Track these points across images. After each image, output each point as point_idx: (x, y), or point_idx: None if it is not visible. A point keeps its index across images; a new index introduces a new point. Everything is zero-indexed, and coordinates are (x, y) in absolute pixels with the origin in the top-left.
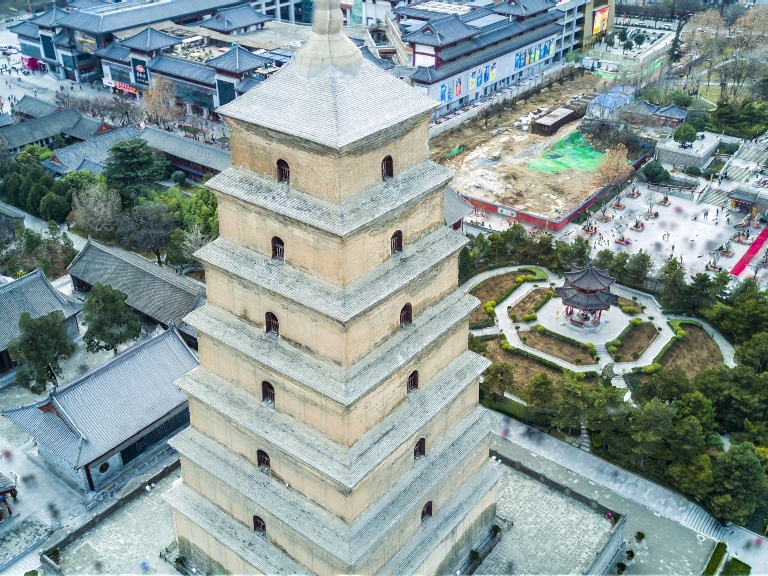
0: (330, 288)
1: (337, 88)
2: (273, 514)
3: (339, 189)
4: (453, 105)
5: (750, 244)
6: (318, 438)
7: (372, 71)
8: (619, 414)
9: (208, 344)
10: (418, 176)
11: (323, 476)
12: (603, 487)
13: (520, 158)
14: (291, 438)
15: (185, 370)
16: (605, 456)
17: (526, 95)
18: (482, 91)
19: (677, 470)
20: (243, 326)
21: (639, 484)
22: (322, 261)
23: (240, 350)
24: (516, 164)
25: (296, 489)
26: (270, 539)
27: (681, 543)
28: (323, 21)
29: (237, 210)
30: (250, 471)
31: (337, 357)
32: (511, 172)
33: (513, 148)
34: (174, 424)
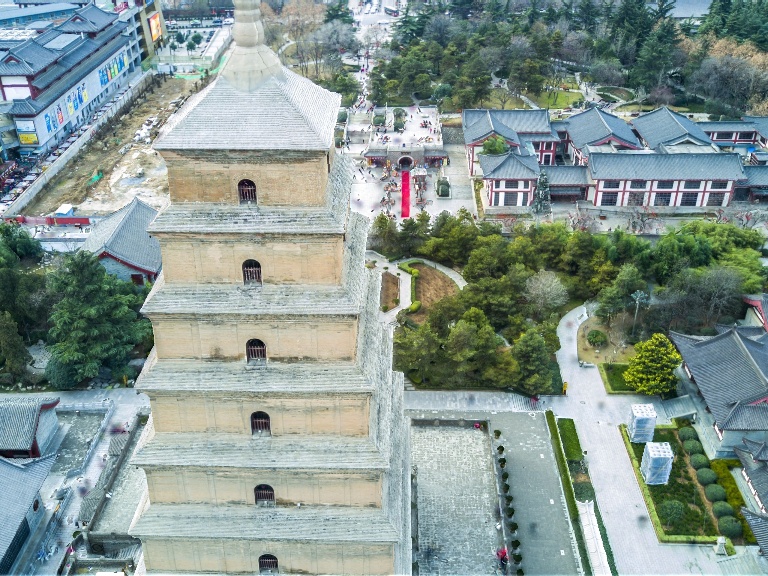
0: (326, 290)
1: (285, 96)
2: (296, 539)
3: (321, 191)
4: (59, 134)
5: (401, 190)
6: (332, 441)
7: (290, 76)
8: (435, 346)
9: (169, 403)
10: (341, 168)
11: (348, 474)
12: (445, 411)
13: (164, 169)
14: (304, 454)
15: (7, 480)
16: (430, 387)
17: (125, 109)
18: (81, 114)
19: (493, 372)
20: (217, 366)
21: (467, 397)
22: (313, 266)
23: (228, 390)
24: (164, 175)
25: (311, 504)
26: (284, 570)
27: (524, 425)
28: (252, 33)
29: (191, 247)
30: (248, 513)
31: (345, 353)
32: (165, 184)
33: (150, 161)
34: (17, 545)
